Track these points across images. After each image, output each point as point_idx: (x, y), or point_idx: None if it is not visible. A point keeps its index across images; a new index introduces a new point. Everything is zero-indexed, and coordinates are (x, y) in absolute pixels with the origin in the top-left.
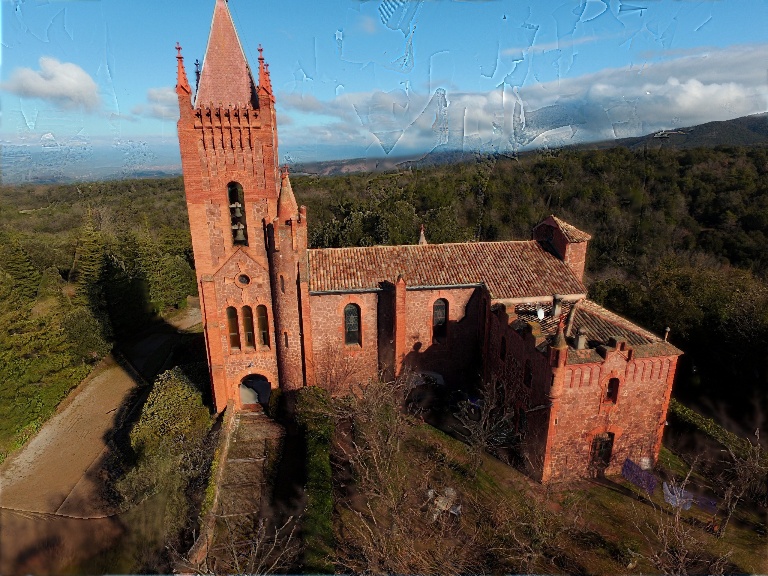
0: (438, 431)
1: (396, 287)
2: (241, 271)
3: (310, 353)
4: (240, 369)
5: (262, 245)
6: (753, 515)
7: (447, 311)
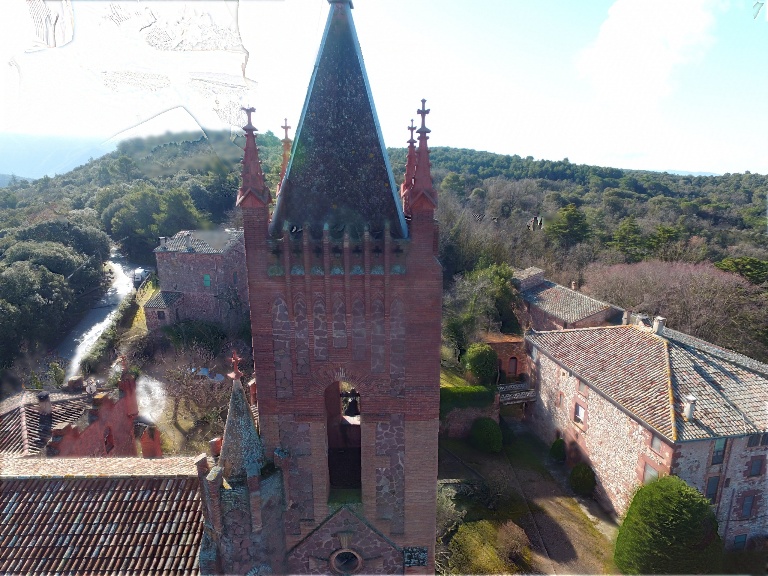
0: None
1: None
2: None
3: None
4: None
5: None
6: None
7: None
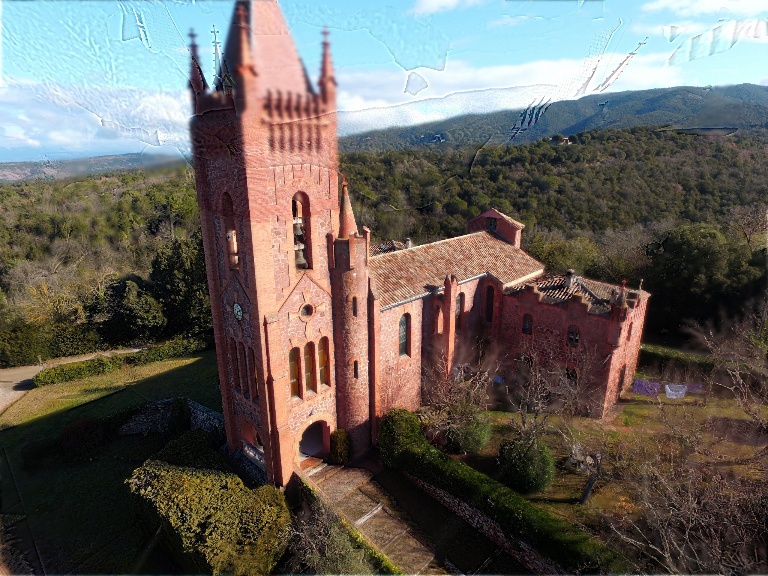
0: (496, 412)
1: (451, 287)
2: (306, 301)
3: (379, 377)
4: (301, 422)
5: (325, 265)
6: (698, 388)
7: (462, 304)
